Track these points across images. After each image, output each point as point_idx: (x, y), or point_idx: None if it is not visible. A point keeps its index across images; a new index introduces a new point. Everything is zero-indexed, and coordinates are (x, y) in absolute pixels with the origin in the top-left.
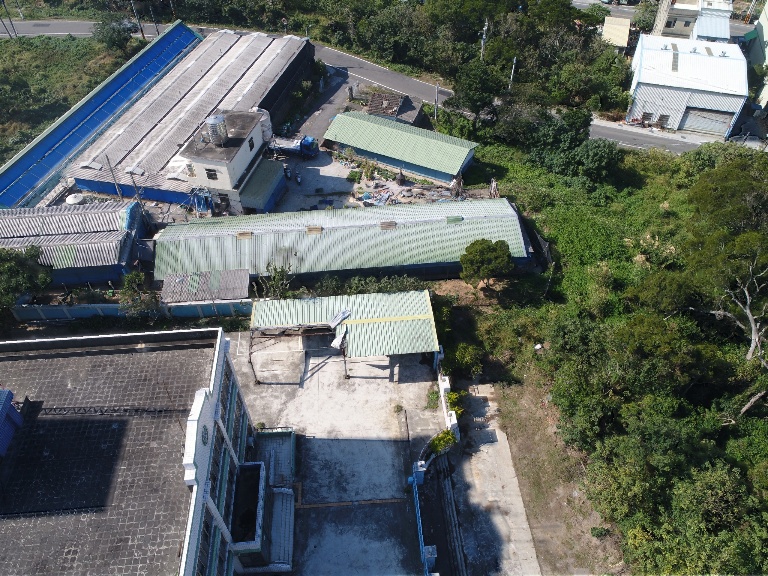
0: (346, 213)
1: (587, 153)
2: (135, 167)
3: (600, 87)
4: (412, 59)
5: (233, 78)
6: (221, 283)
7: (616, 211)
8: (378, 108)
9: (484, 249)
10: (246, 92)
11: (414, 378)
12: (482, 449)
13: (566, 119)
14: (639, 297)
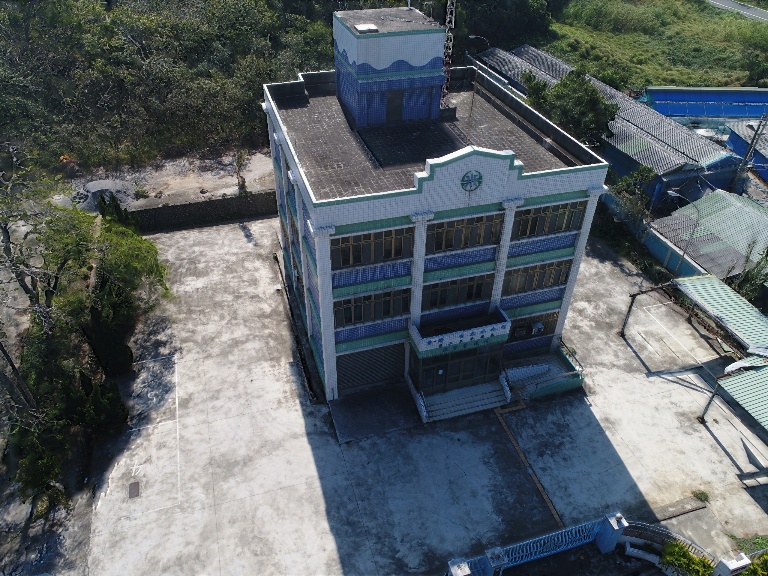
0: None
1: None
2: None
3: None
4: None
5: None
6: (716, 252)
7: None
8: None
9: None
10: None
11: None
12: None
13: None
14: None
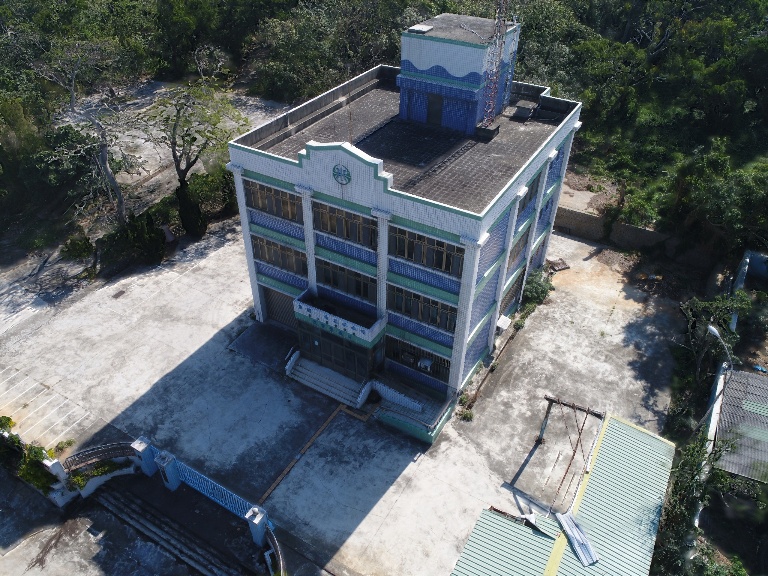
0: None
1: None
2: None
3: None
4: None
5: None
6: (758, 442)
7: None
8: None
9: None
10: None
11: None
12: None
13: None
14: None
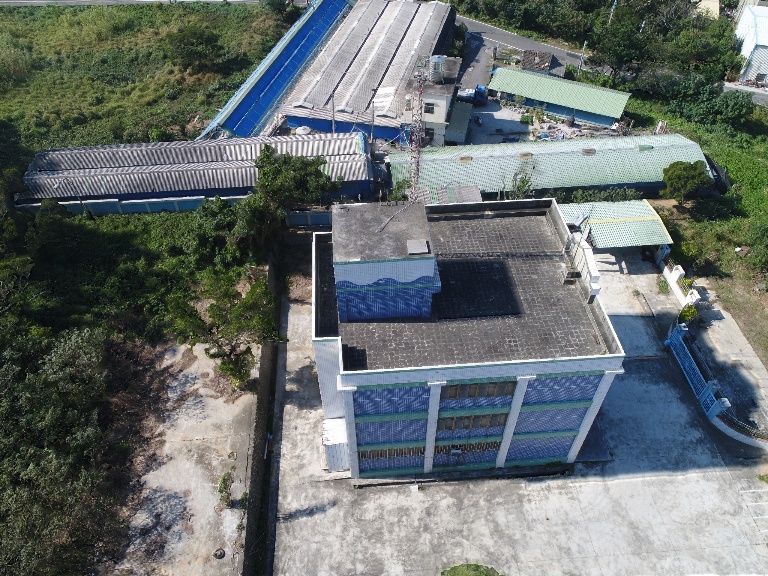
0: (543, 144)
1: (726, 103)
2: (345, 106)
3: (716, 51)
4: (538, 26)
5: (398, 36)
6: (457, 196)
7: (759, 152)
8: (531, 64)
9: (687, 167)
10: (416, 47)
11: (641, 271)
12: (714, 324)
13: (704, 74)
14: None
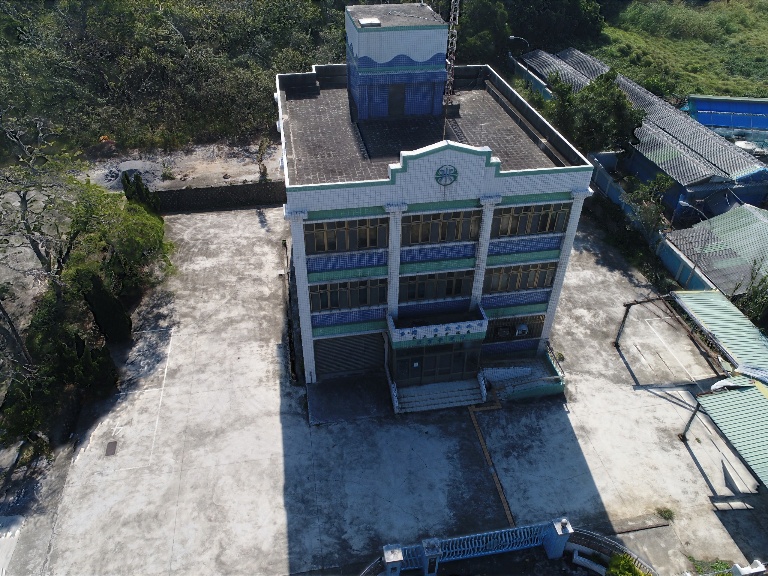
0: None
1: None
2: None
3: None
4: None
5: None
6: (730, 268)
7: None
8: None
9: None
10: None
11: (740, 535)
12: None
13: None
14: None
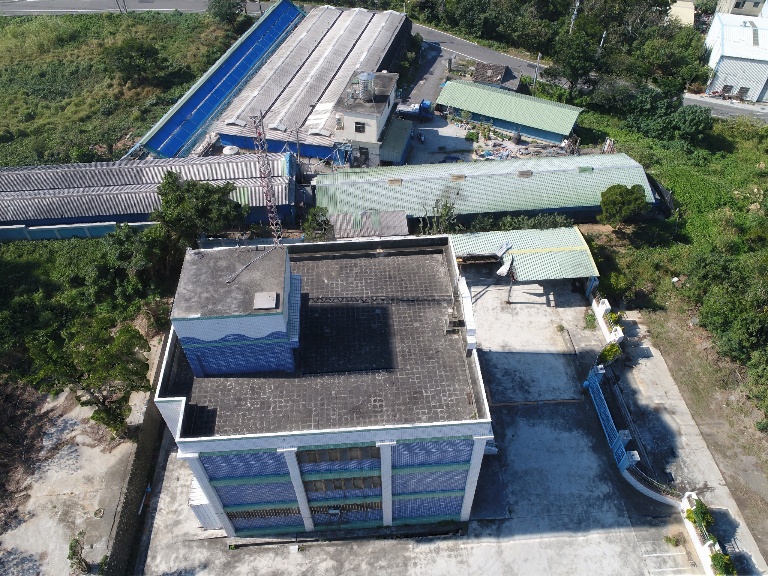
0: (480, 165)
1: (684, 118)
2: (278, 124)
3: (682, 61)
4: (499, 35)
5: (346, 48)
6: (382, 222)
7: (716, 170)
8: (483, 76)
9: (623, 192)
10: (362, 60)
11: (569, 304)
12: (641, 362)
13: (662, 87)
14: (763, 237)
